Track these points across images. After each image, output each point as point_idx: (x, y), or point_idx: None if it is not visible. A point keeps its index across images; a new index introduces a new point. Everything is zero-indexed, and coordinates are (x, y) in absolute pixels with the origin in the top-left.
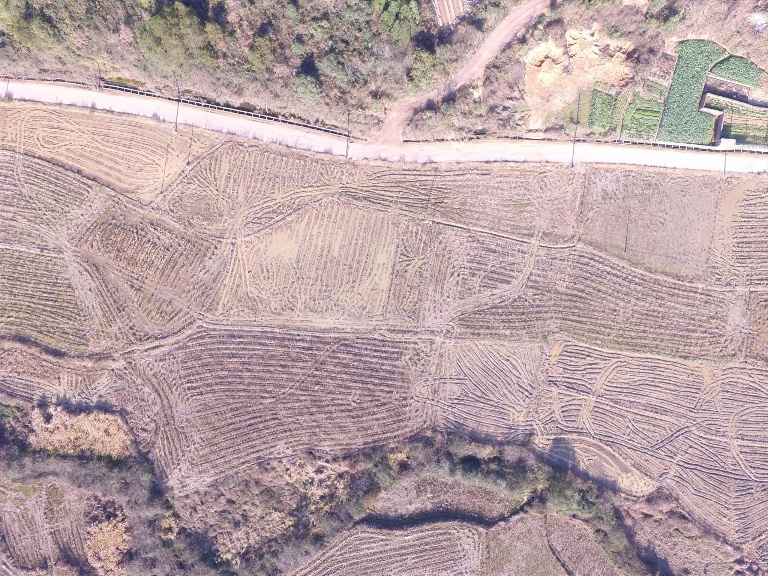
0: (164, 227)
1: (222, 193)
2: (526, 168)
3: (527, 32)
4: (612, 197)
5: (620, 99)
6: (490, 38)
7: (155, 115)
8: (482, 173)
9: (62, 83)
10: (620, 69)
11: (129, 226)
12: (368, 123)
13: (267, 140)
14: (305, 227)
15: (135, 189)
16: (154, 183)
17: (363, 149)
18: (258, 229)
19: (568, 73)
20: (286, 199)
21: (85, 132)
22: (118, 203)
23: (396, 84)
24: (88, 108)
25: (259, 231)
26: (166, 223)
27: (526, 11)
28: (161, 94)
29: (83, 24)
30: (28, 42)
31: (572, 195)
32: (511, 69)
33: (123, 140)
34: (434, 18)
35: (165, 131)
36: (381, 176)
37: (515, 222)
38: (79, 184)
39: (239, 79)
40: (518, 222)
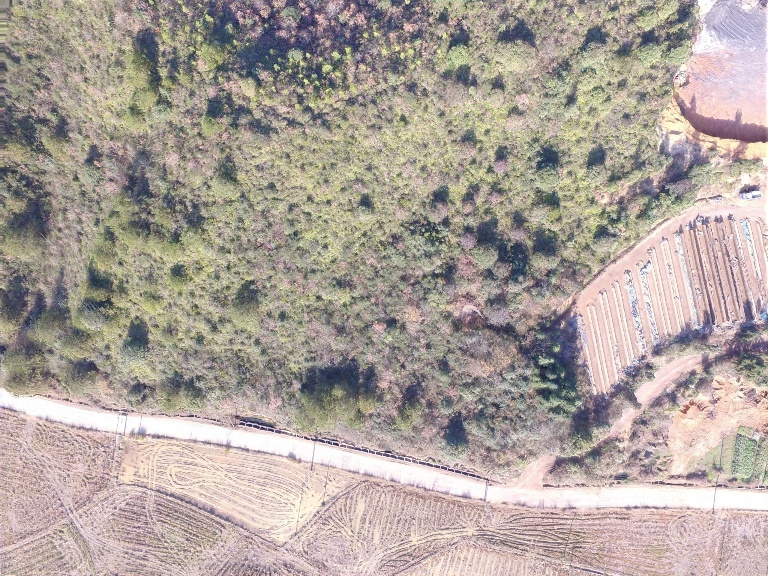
0: (297, 568)
1: (357, 535)
2: (666, 512)
3: (678, 391)
4: (752, 543)
5: (764, 446)
6: (638, 392)
7: (291, 454)
8: (621, 517)
9: (196, 419)
10: (765, 414)
11: (262, 567)
12: (510, 473)
13: (404, 482)
14: (440, 570)
15: (269, 529)
16: (288, 523)
17: (502, 492)
18: (393, 572)
19: (712, 418)
20: (422, 542)
21: (219, 469)
22: (251, 543)
23: (545, 447)
24: (223, 446)
25: (394, 575)
26: (300, 564)
27: (677, 367)
28: (298, 434)
29: (232, 393)
30: (170, 396)
31: (711, 540)
32: (658, 423)
33: (257, 478)
34: (589, 388)
35: (300, 469)
36: (519, 519)
37: (653, 568)
38: (212, 523)
39: (384, 435)
40: (656, 568)
